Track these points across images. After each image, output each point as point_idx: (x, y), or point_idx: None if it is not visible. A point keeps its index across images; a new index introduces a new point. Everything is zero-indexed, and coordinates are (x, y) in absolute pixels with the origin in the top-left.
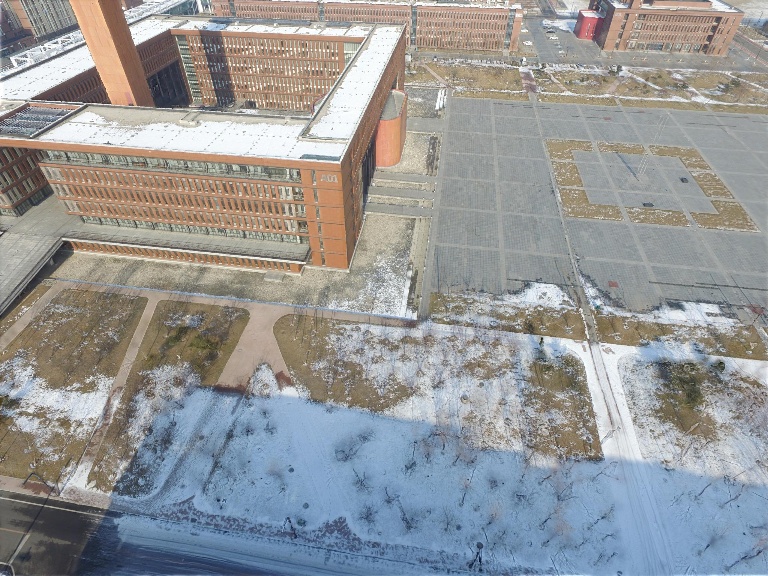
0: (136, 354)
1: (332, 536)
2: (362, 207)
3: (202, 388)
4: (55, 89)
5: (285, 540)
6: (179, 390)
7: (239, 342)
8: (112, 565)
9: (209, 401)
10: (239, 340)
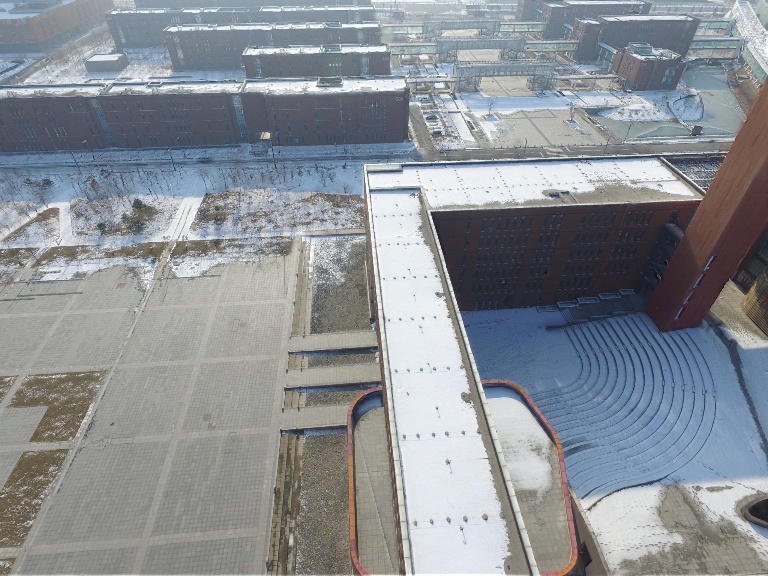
0: None
1: (331, 167)
2: None
3: None
4: None
5: None
6: None
7: None
8: (408, 155)
9: None
10: None
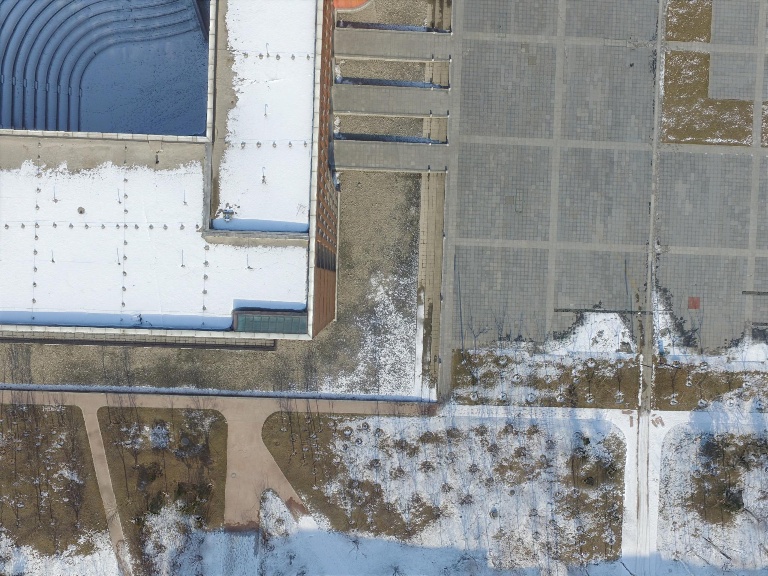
0: (114, 497)
1: None
2: (334, 193)
3: (211, 532)
4: None
5: None
6: (187, 538)
7: (228, 464)
8: None
9: (225, 545)
10: (227, 461)
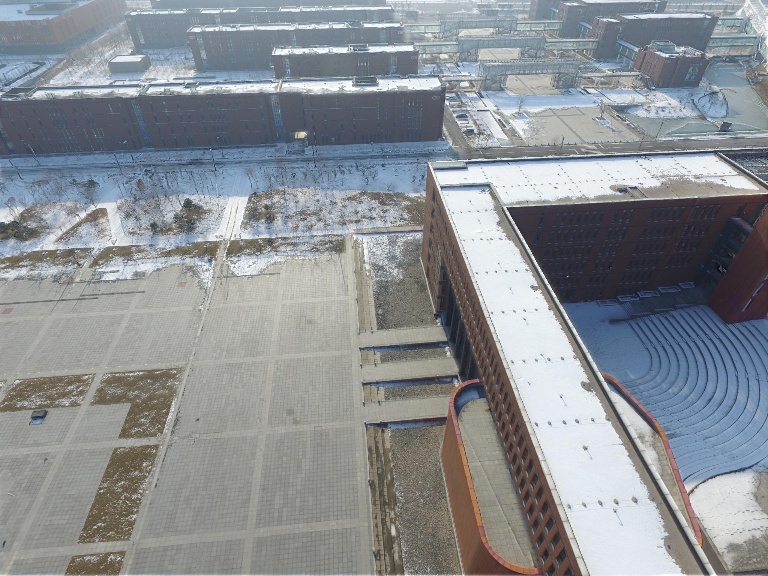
0: None
1: None
2: None
3: None
4: None
5: (387, 163)
6: None
7: None
8: (445, 153)
9: None
10: None
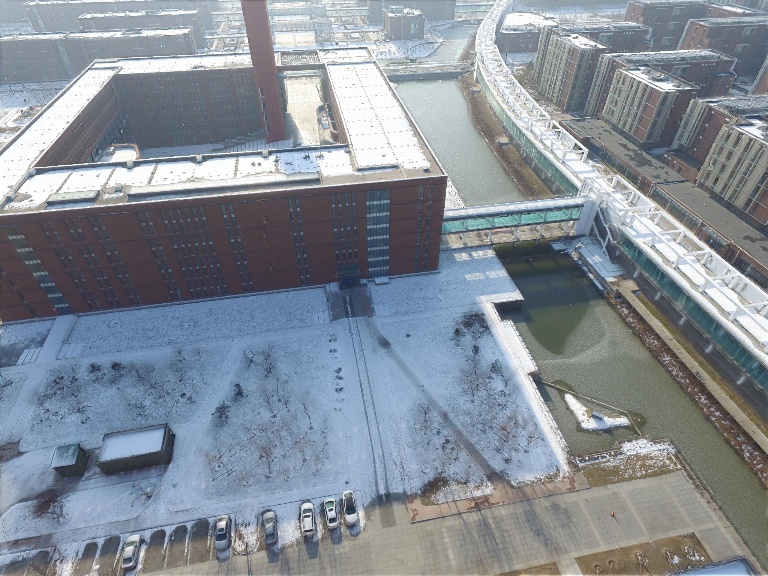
0: None
1: None
2: None
3: None
4: None
5: None
6: None
7: None
8: None
9: None
10: None
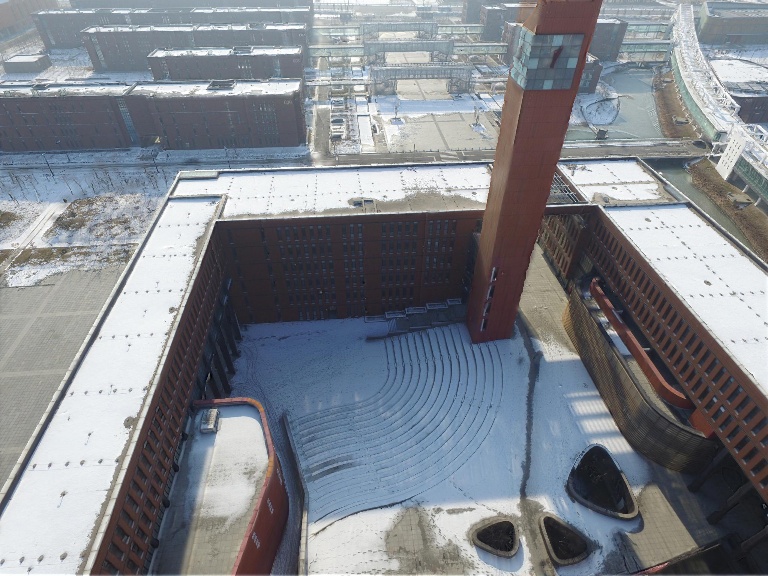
0: None
1: None
2: None
3: None
4: (621, 236)
5: None
6: None
7: None
8: (299, 159)
9: None
10: None
